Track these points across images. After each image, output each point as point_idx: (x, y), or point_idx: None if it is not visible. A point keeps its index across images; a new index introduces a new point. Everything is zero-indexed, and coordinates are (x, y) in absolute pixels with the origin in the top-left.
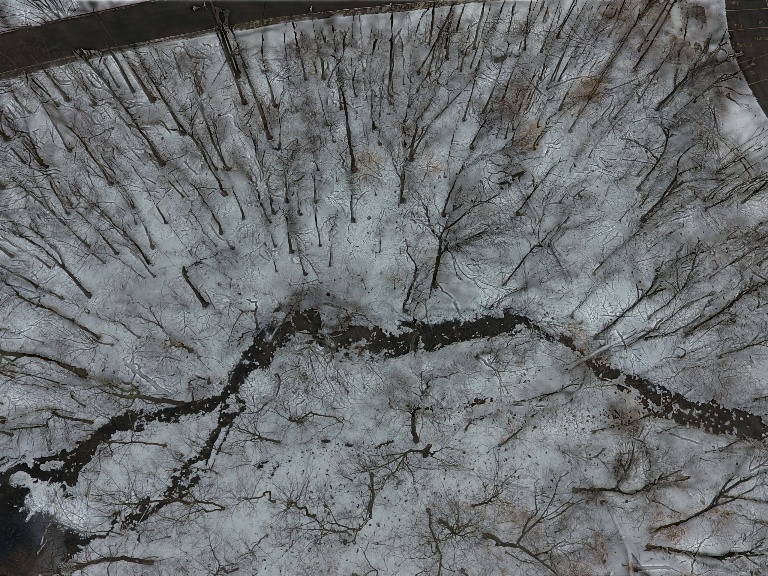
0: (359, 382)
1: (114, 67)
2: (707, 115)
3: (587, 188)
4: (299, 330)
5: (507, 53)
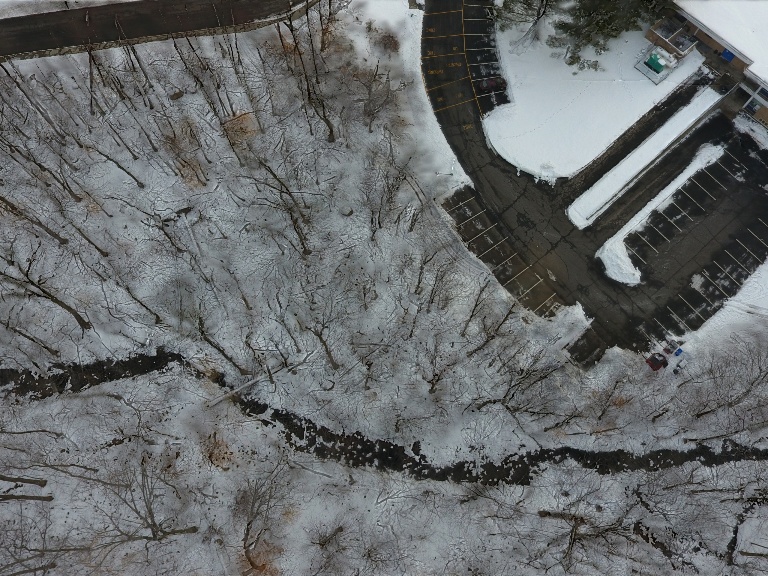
0: None
1: None
2: (383, 144)
3: None
4: None
5: (183, 90)
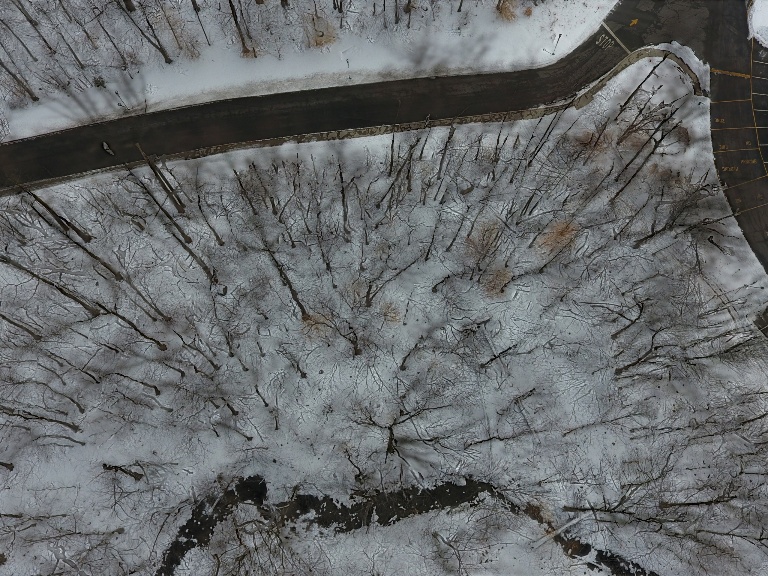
0: (305, 565)
1: (42, 210)
2: (689, 252)
3: (558, 335)
4: (242, 500)
5: (474, 184)
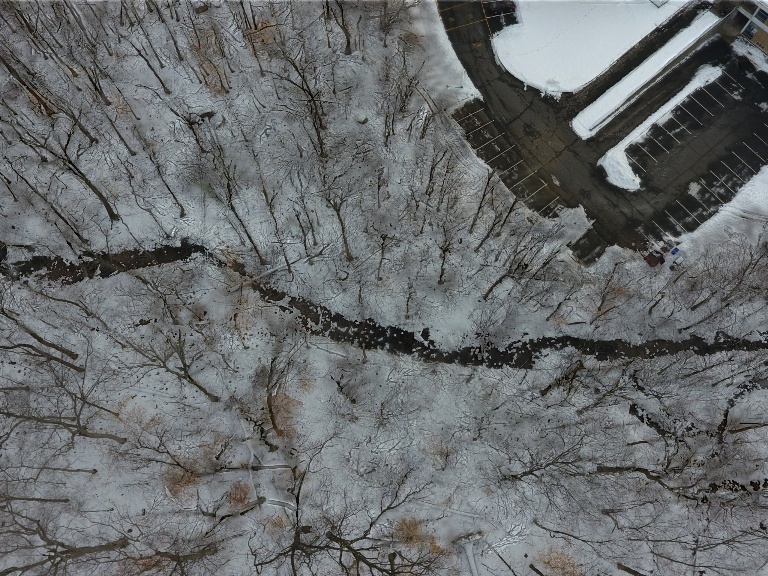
0: None
1: None
2: (397, 58)
3: None
4: None
5: (208, 4)
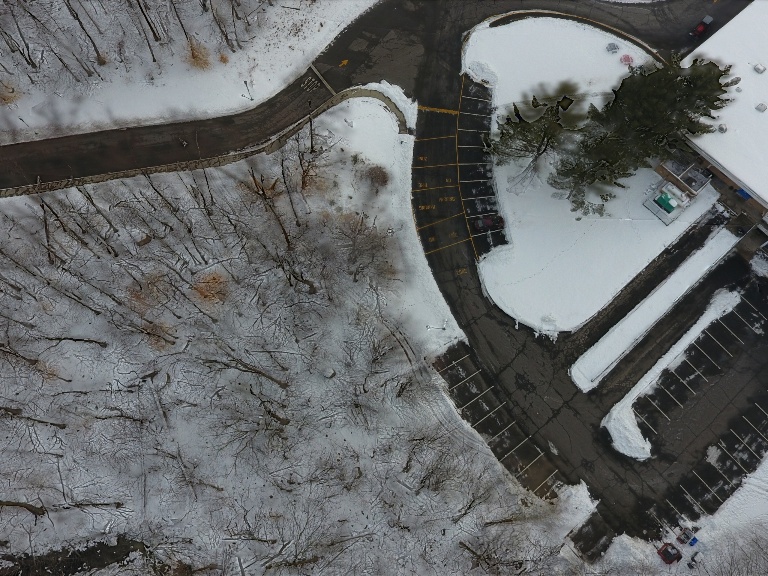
0: None
1: None
2: (369, 295)
3: (227, 386)
4: None
5: (151, 235)
